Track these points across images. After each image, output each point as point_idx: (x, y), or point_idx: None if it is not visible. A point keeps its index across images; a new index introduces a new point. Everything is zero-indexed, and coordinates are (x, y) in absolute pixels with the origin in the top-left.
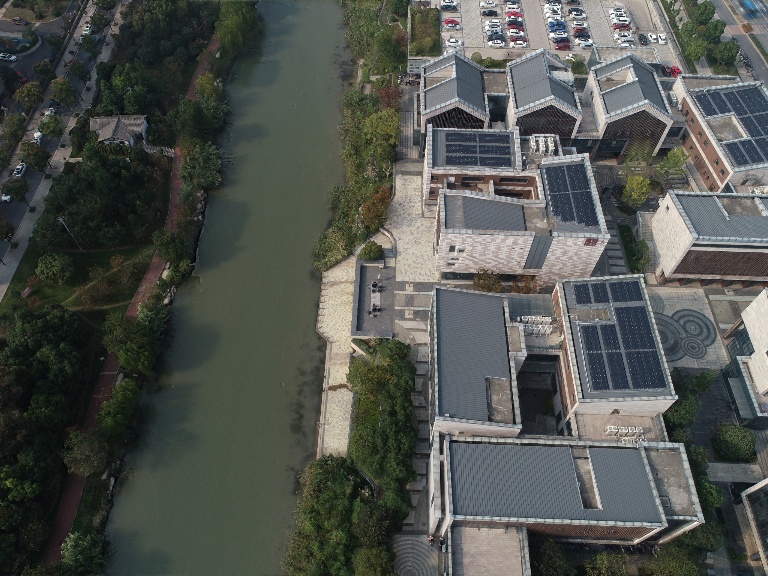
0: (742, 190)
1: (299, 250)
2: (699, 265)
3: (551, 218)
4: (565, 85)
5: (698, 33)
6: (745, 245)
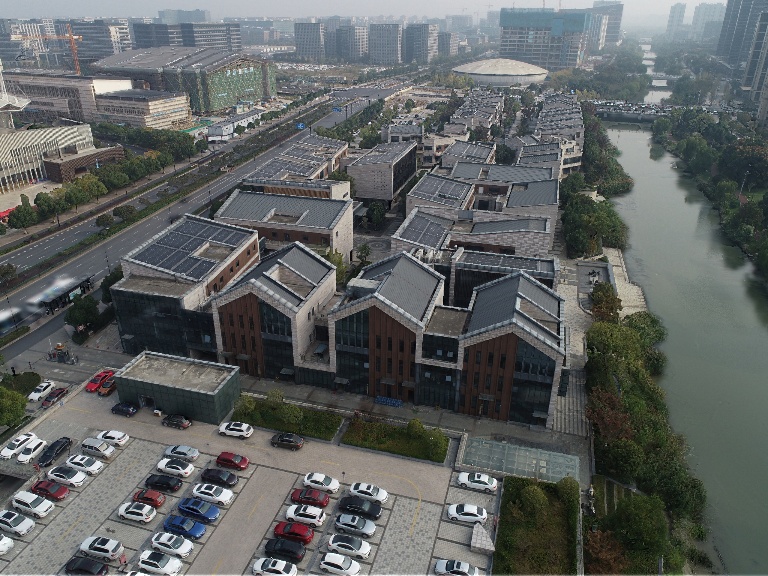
0: None
1: (683, 334)
2: None
3: (449, 228)
4: None
5: None
6: None
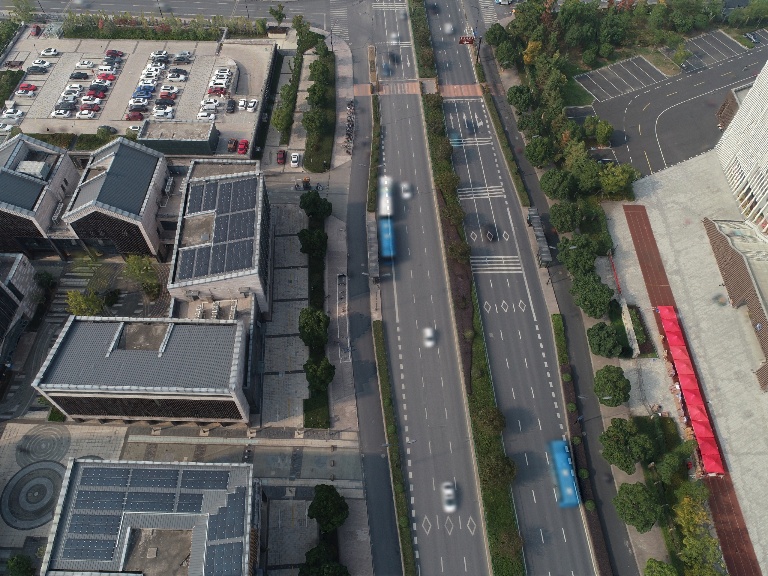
0: (193, 306)
1: None
2: (87, 408)
3: None
4: (30, 178)
5: None
6: (104, 392)
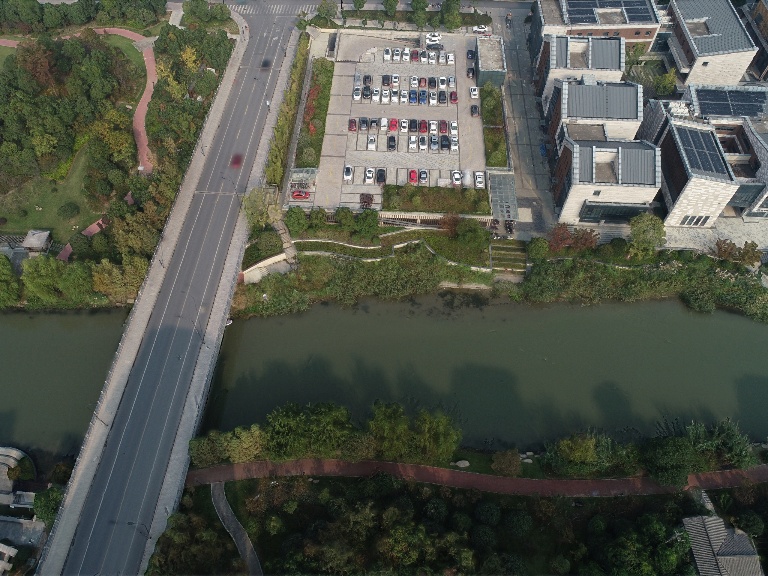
0: None
1: None
2: None
3: (761, 118)
4: None
5: (403, 20)
6: None
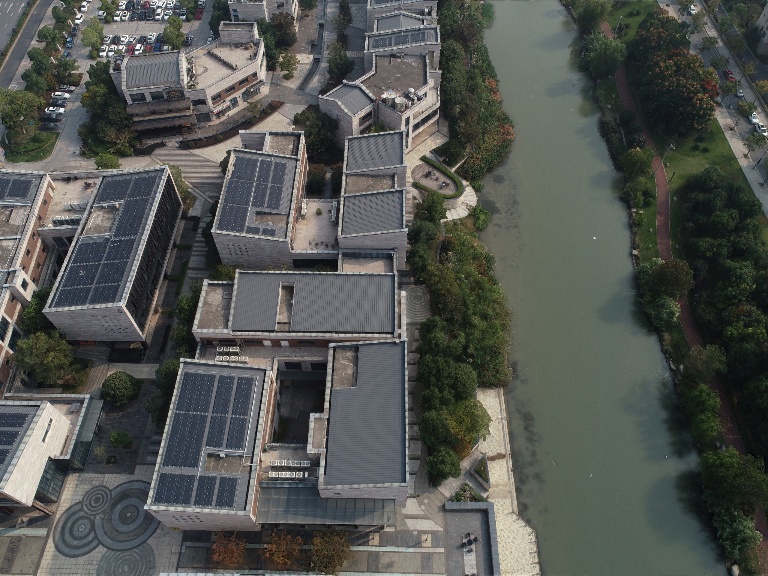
0: None
1: None
2: None
3: None
4: None
5: None
6: None
